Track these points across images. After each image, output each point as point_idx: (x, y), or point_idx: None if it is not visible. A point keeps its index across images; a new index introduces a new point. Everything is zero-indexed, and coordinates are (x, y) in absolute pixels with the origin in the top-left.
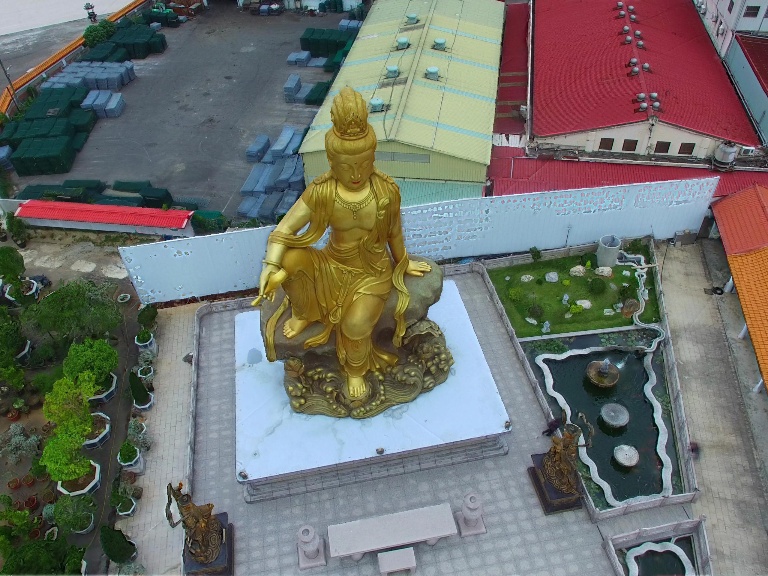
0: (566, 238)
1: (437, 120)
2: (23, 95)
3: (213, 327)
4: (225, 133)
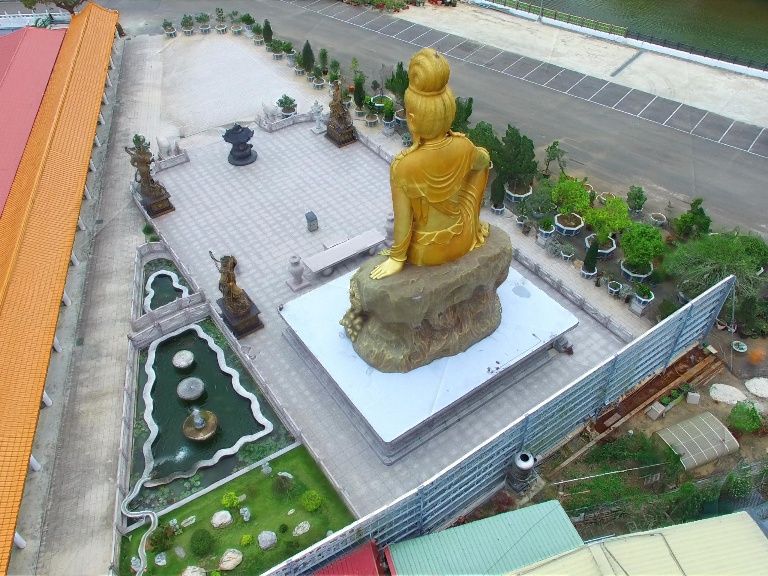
0: None
1: None
2: None
3: (613, 346)
4: None
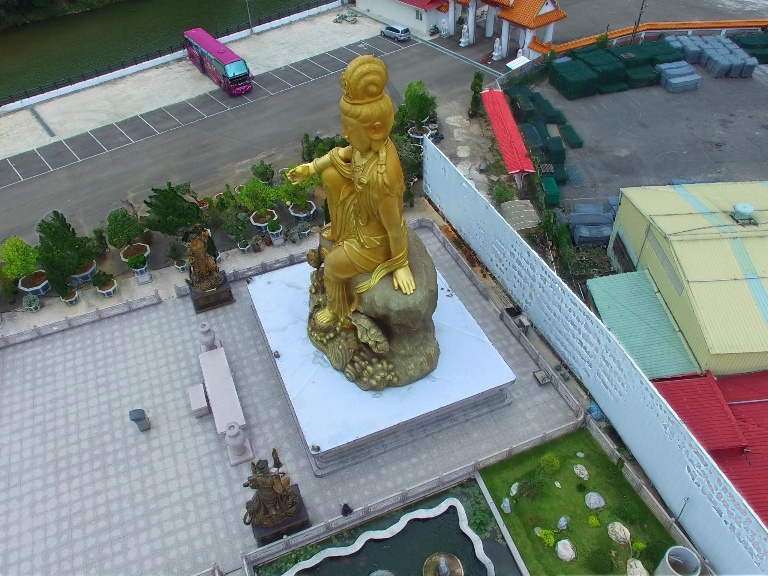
0: (681, 509)
1: (763, 276)
2: (653, 37)
3: None
4: (704, 161)
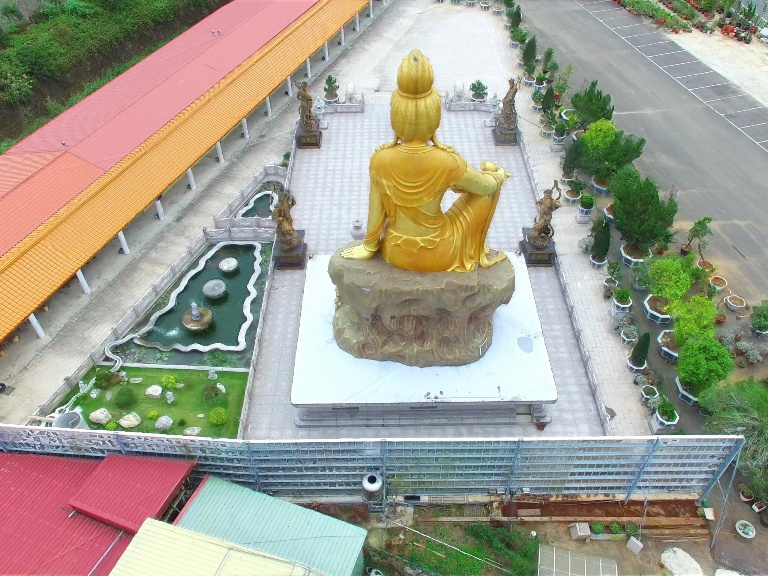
0: None
1: None
2: None
3: None
4: None
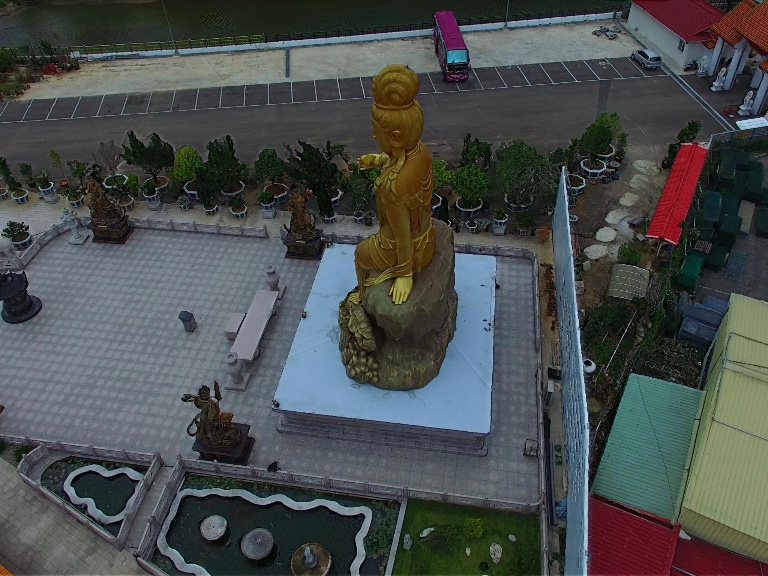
0: None
1: None
2: None
3: (514, 264)
4: None
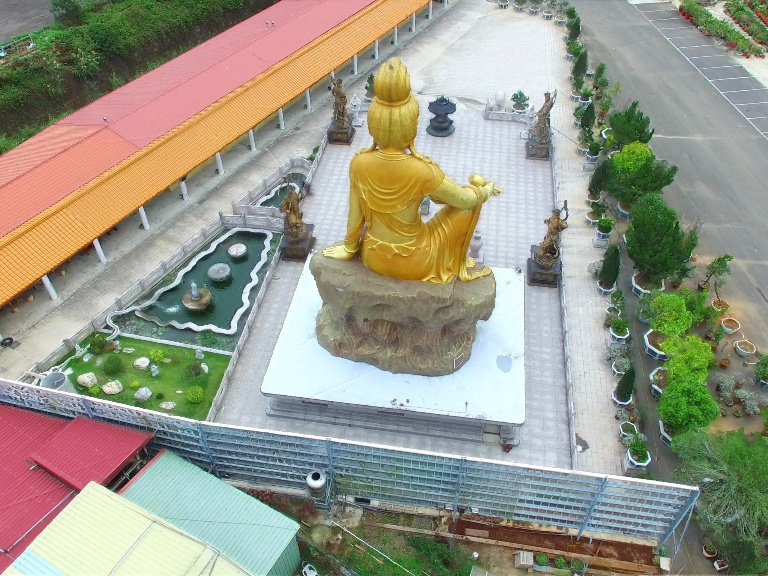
0: None
1: None
2: None
3: None
4: None
